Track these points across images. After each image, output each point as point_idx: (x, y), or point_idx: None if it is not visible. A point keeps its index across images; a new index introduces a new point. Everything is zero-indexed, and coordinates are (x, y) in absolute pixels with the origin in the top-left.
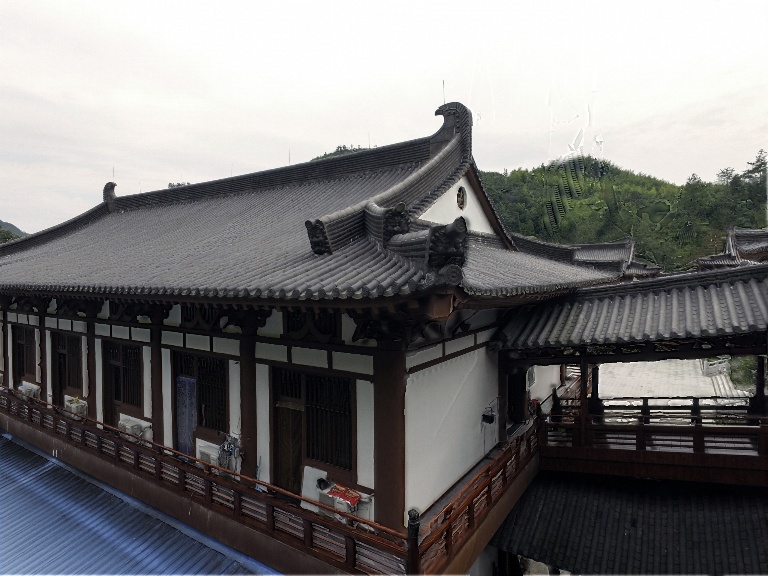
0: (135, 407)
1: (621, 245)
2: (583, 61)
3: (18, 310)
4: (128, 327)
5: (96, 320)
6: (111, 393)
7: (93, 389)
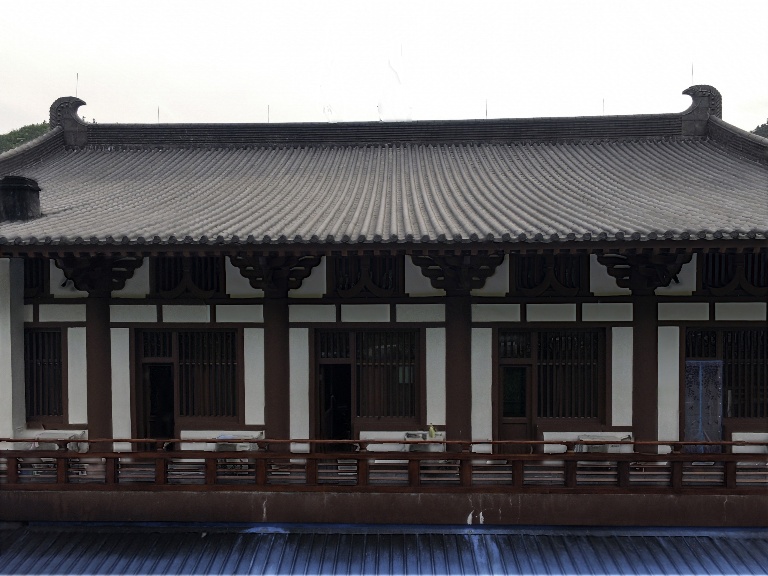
0: (571, 418)
1: None
2: None
3: (168, 298)
4: (575, 304)
5: (476, 299)
6: (499, 408)
7: (466, 408)
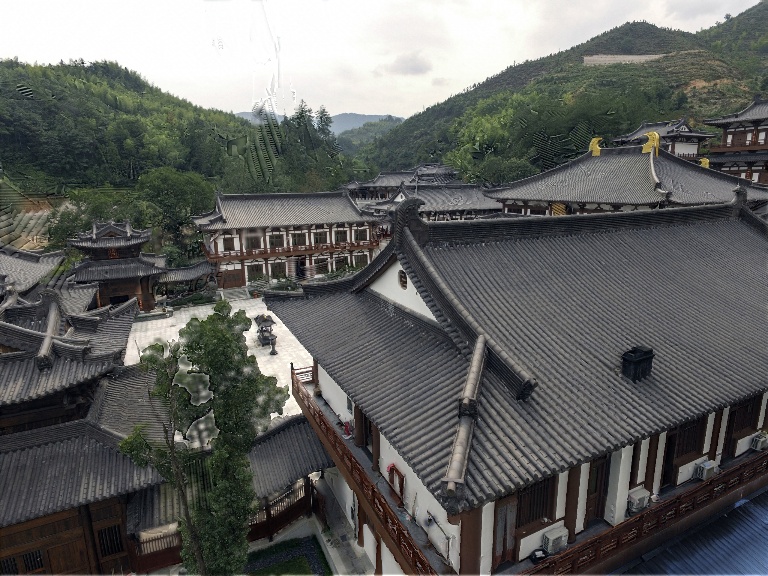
0: None
1: (339, 194)
2: (268, 1)
3: None
4: None
5: None
6: None
7: None
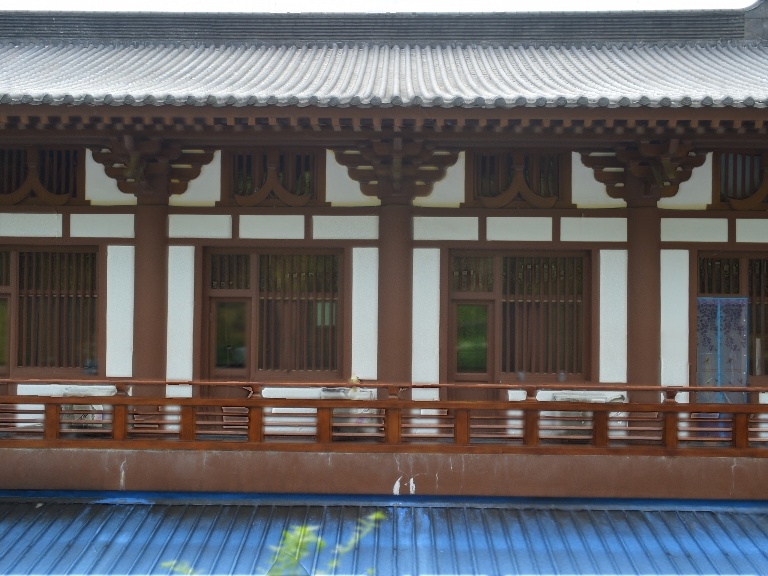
0: (547, 373)
1: None
2: None
3: (6, 203)
4: (551, 217)
5: (420, 210)
6: (451, 359)
7: (405, 355)
